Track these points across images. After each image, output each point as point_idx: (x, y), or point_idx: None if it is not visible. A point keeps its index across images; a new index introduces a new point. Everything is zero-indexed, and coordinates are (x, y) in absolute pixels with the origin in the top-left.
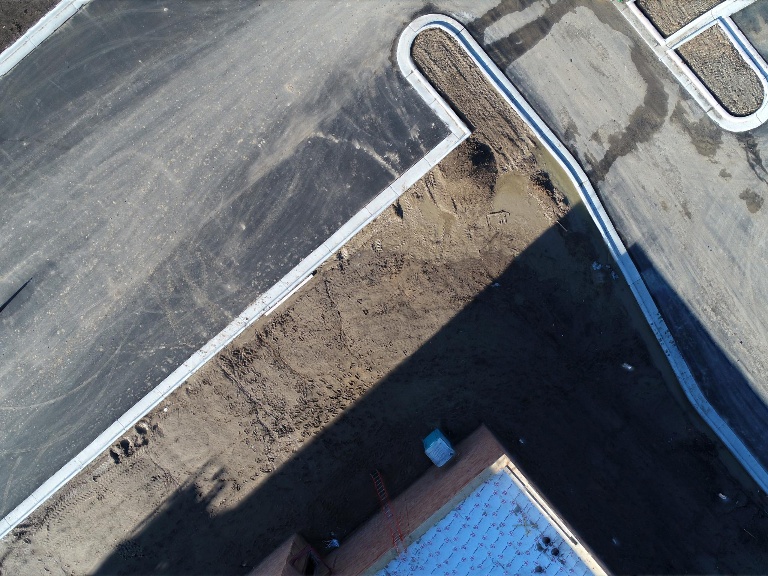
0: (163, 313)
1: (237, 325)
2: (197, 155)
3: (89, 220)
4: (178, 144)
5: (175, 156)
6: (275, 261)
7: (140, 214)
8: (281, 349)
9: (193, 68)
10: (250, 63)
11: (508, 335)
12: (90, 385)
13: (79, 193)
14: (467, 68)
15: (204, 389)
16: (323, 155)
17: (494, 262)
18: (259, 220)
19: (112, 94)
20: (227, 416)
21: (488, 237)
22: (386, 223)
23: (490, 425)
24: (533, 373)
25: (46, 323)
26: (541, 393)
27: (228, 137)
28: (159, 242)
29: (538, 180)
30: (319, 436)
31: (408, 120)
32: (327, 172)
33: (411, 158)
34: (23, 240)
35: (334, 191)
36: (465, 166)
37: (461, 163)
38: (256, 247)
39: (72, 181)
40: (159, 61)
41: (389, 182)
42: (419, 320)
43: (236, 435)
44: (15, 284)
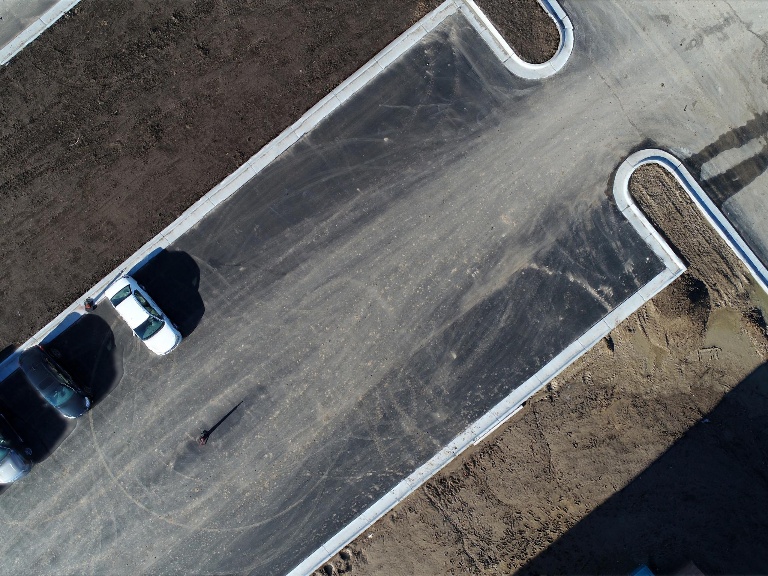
0: (371, 440)
1: (445, 454)
2: (411, 283)
3: (301, 345)
4: (392, 272)
5: (389, 284)
6: (485, 391)
7: (352, 340)
8: (489, 479)
9: (410, 197)
10: (467, 194)
11: (718, 472)
12: (296, 509)
13: (292, 318)
14: (683, 204)
15: (410, 517)
16: (536, 286)
17: (705, 398)
18: (470, 349)
19: (329, 221)
20: (433, 545)
21: (699, 373)
22: (597, 356)
23: (699, 563)
24: (742, 511)
25: (254, 446)
26: (749, 531)
27: (442, 266)
28: (370, 369)
29: (752, 317)
30: (525, 569)
31: (622, 254)
32: (540, 303)
33: (625, 292)
34: (235, 364)
35: (546, 323)
36: (682, 303)
37: (677, 300)
38: (466, 376)
39: (286, 306)
40: (377, 190)
41: (602, 315)
42: (629, 455)
43: (442, 565)
44: (225, 407)
